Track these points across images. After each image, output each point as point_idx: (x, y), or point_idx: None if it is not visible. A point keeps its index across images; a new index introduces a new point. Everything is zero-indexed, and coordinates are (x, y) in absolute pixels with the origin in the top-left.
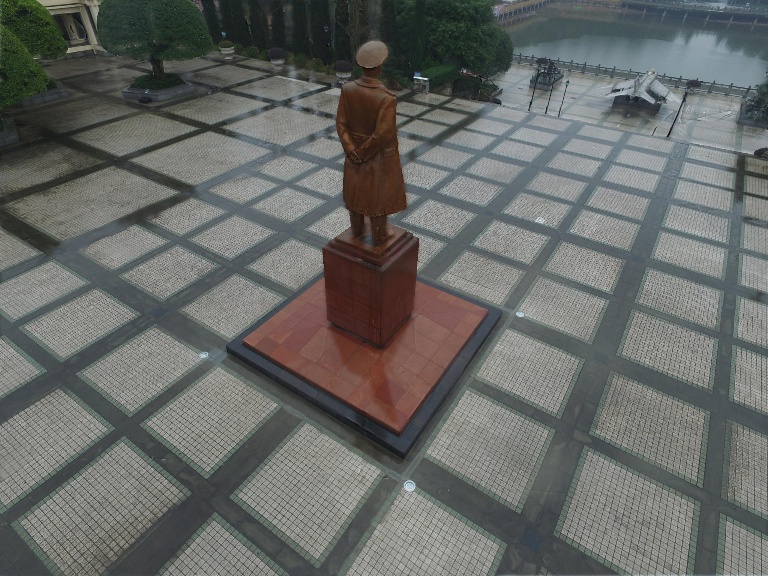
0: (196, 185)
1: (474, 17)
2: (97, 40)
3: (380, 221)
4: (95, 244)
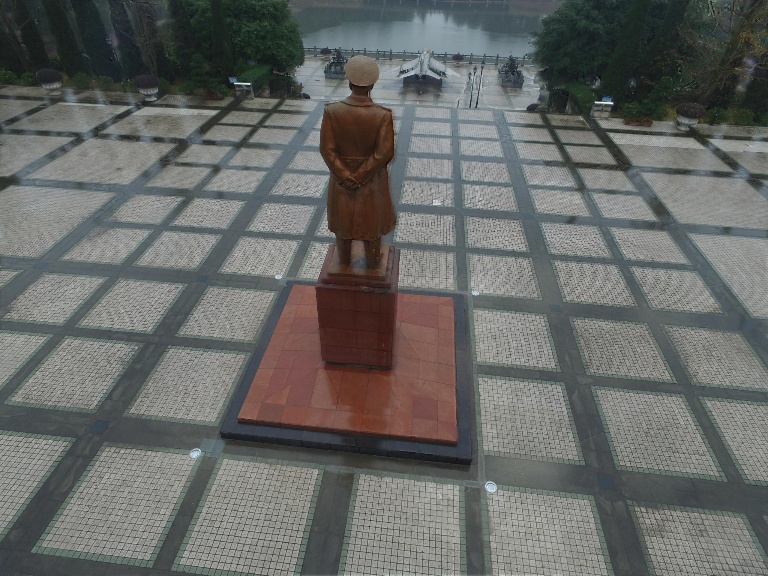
0: (39, 256)
1: (274, 15)
2: None
3: (376, 242)
4: None
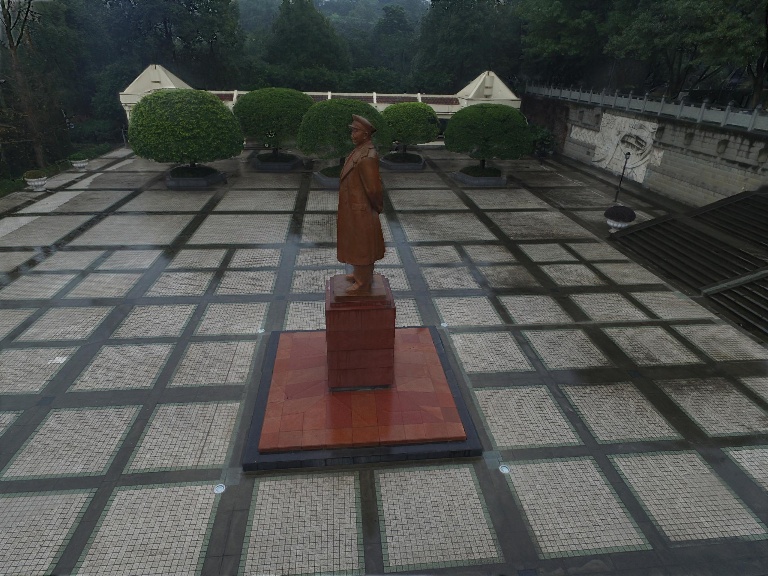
0: None
1: None
2: None
3: None
4: None
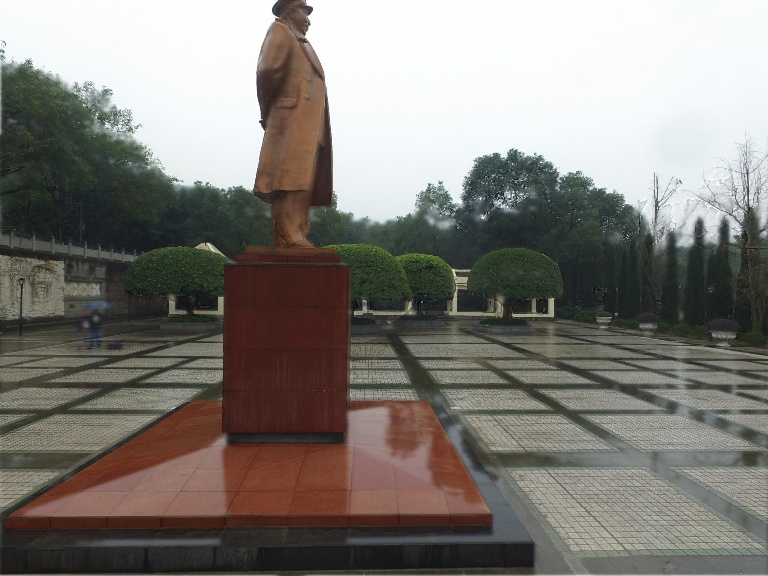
0: (417, 357)
1: None
2: (501, 310)
3: (276, 209)
4: None
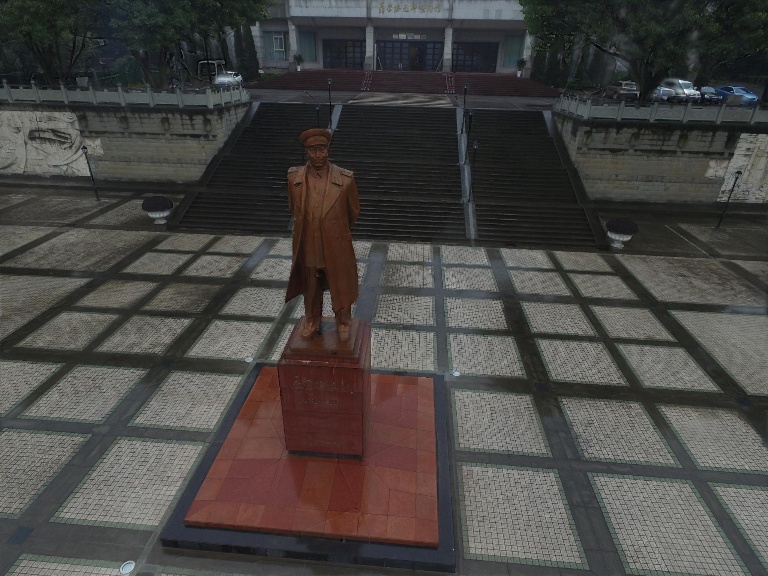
0: None
1: None
2: None
3: None
4: (744, 425)
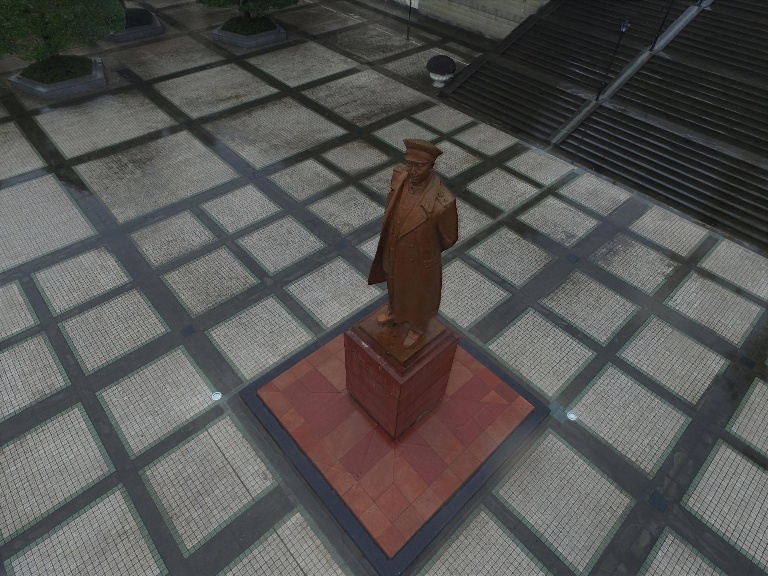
0: None
1: None
2: None
3: None
4: None
